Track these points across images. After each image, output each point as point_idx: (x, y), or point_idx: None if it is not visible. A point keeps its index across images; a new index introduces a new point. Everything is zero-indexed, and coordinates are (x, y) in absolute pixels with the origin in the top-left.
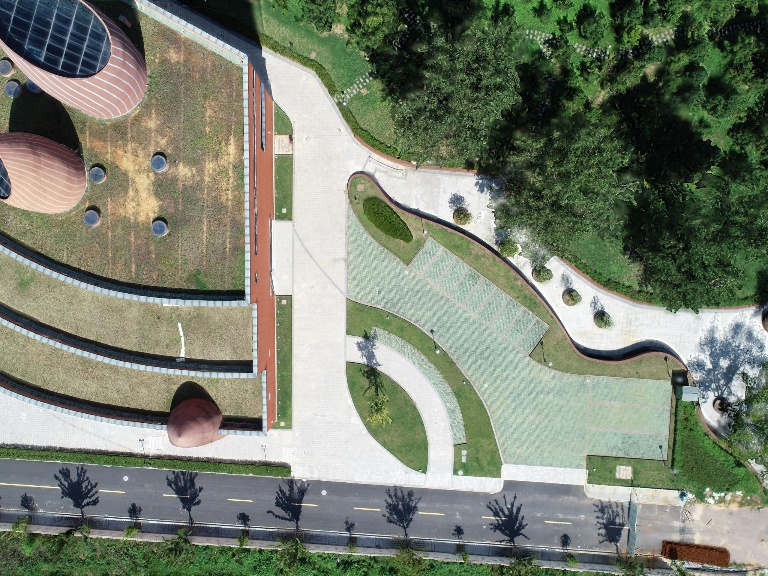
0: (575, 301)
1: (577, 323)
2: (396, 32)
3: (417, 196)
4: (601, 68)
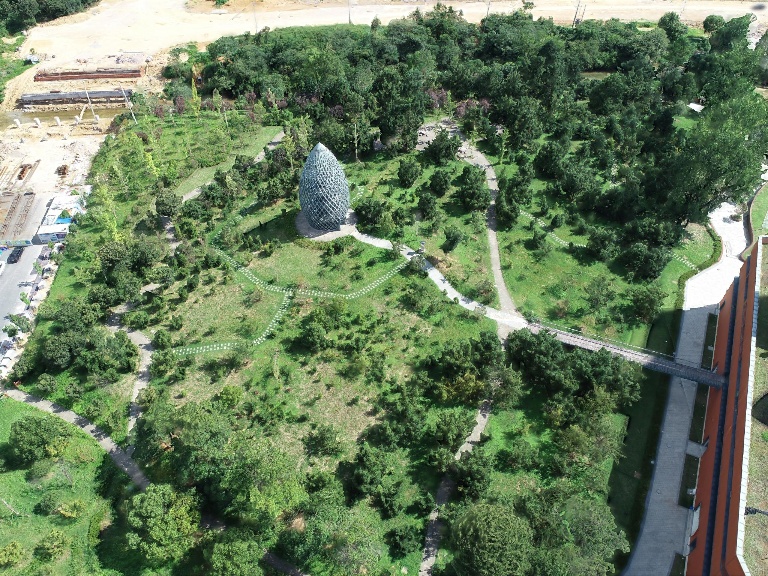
0: None
1: (765, 176)
2: None
3: (736, 237)
4: (622, 162)
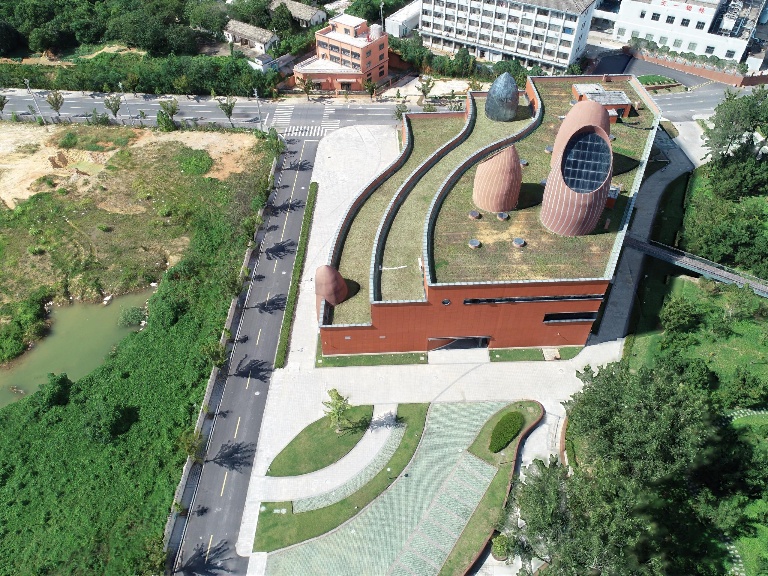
0: None
1: None
2: None
3: None
4: None
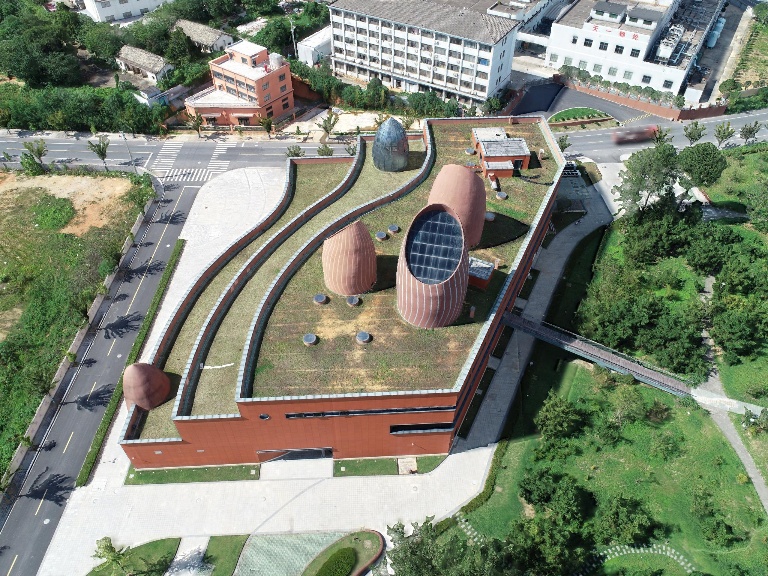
0: None
1: None
2: (536, 567)
3: None
4: None
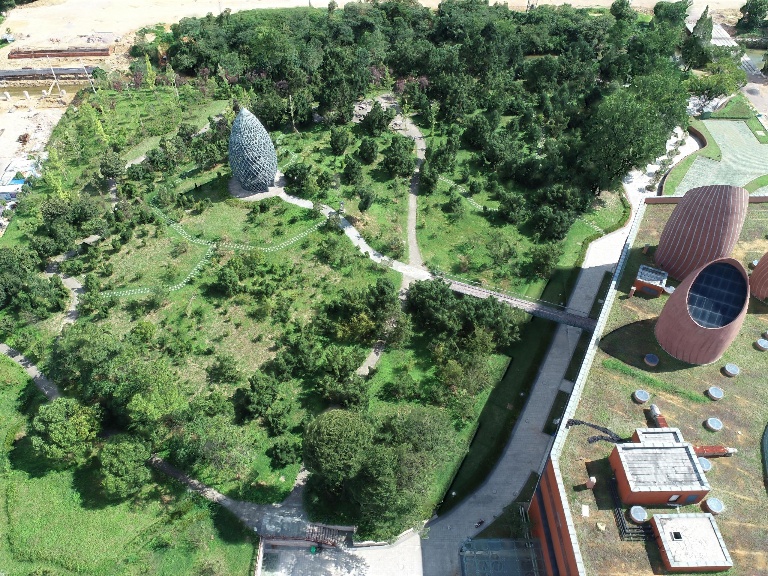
0: (677, 150)
1: (688, 151)
2: None
3: None
4: (550, 137)
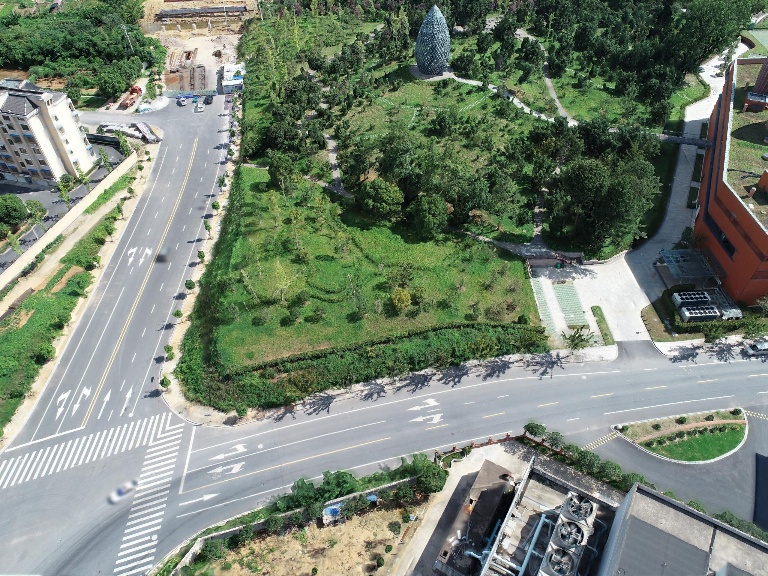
0: None
1: None
2: None
3: (720, 85)
4: None
